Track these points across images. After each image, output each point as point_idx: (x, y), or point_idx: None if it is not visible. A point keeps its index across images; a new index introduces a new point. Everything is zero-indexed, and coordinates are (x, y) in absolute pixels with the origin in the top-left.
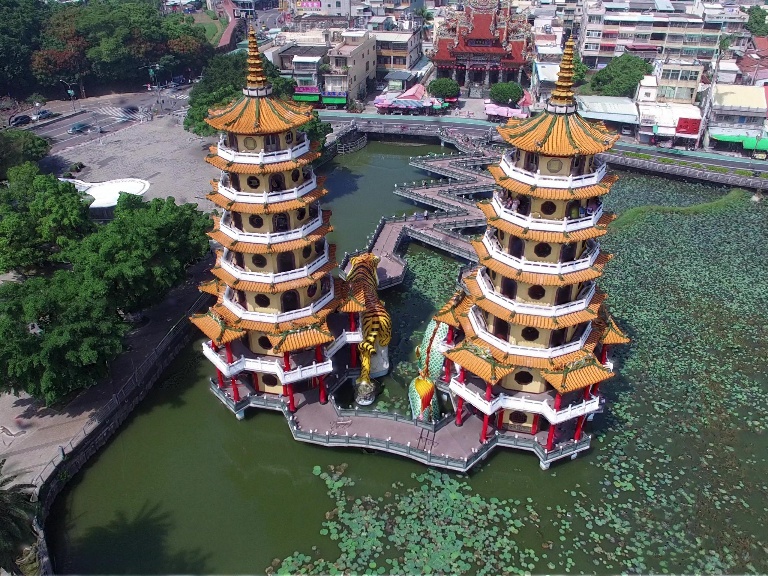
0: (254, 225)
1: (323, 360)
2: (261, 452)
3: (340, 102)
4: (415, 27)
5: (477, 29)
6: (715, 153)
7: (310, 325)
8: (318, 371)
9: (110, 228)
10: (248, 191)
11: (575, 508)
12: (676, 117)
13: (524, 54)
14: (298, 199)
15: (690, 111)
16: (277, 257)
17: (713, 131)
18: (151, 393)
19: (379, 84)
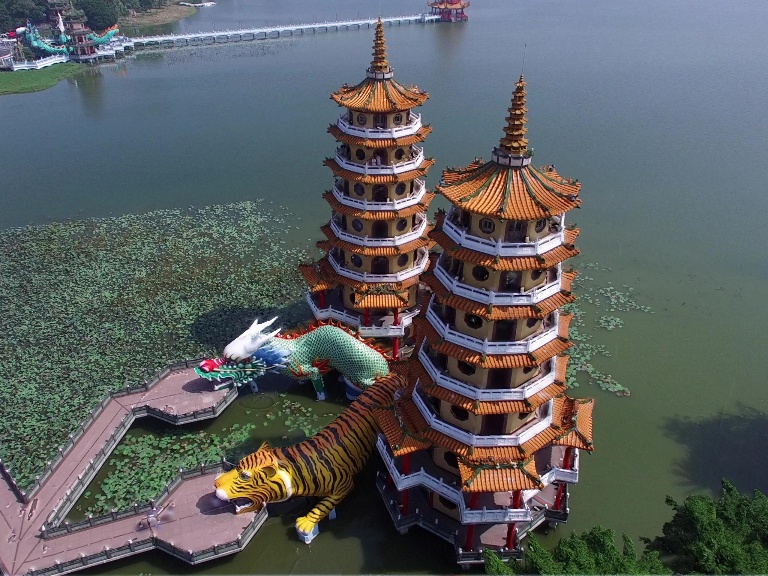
0: None
1: None
2: None
3: None
4: None
5: None
6: None
7: None
8: None
9: None
10: None
11: None
12: None
13: None
14: None
15: None
16: None
17: None
18: None
19: None
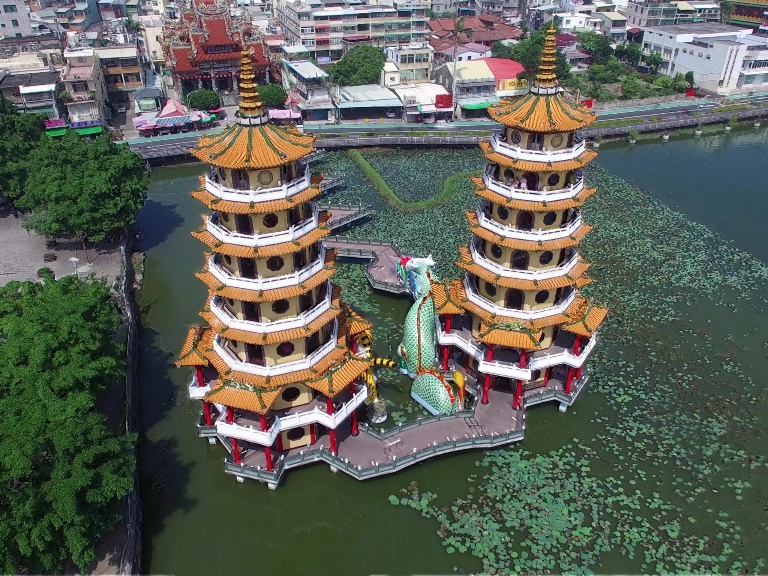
0: (272, 268)
1: (358, 389)
2: (295, 515)
3: (94, 132)
4: (132, 40)
5: (213, 35)
6: (469, 121)
7: (348, 357)
8: (357, 402)
9: (32, 328)
10: (268, 232)
11: (609, 431)
12: (433, 95)
13: (266, 56)
14: (319, 227)
15: (436, 88)
16: (299, 296)
17: (462, 102)
18: (143, 508)
19: (118, 106)
